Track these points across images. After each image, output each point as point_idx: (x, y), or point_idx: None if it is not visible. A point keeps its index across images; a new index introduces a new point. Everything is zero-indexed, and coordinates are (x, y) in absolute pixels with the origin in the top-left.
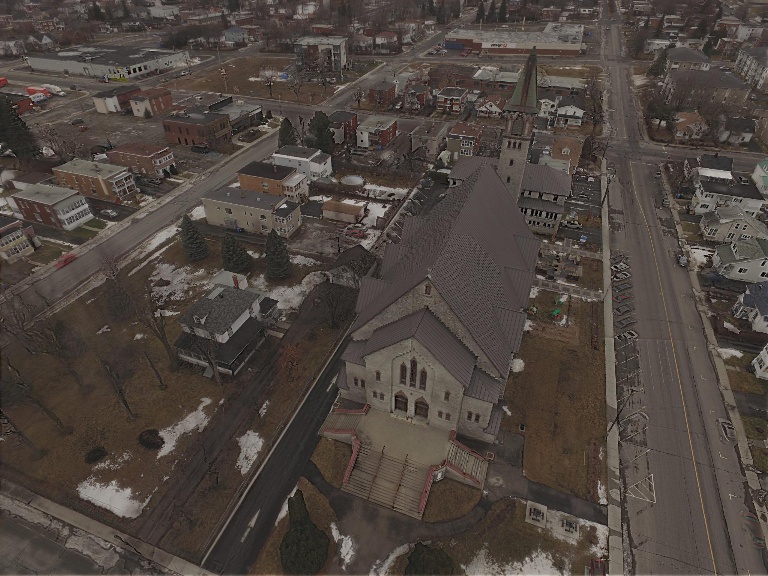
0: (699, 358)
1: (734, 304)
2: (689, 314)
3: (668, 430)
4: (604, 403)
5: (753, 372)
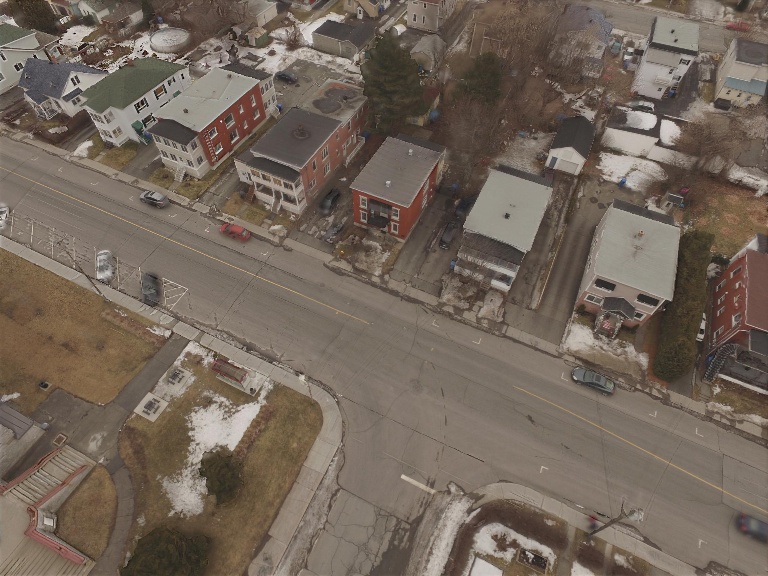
0: (73, 174)
1: (34, 111)
2: (17, 150)
3: (129, 242)
4: (68, 283)
5: (113, 145)
